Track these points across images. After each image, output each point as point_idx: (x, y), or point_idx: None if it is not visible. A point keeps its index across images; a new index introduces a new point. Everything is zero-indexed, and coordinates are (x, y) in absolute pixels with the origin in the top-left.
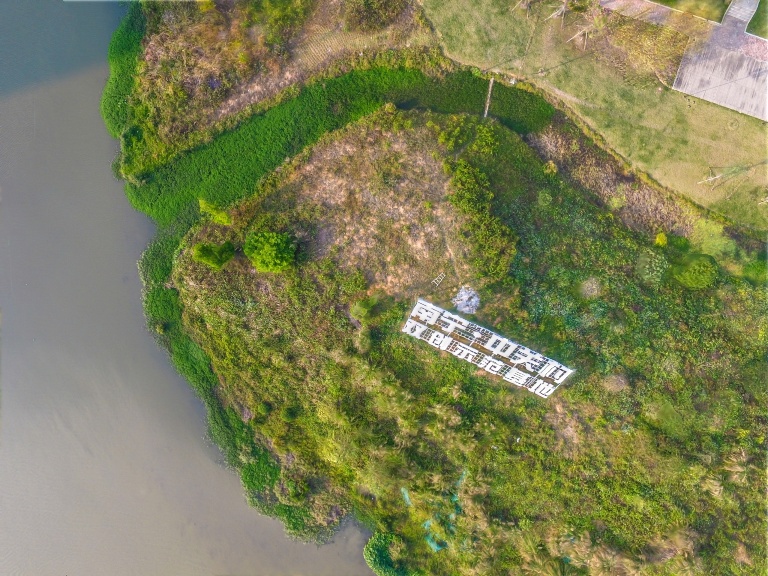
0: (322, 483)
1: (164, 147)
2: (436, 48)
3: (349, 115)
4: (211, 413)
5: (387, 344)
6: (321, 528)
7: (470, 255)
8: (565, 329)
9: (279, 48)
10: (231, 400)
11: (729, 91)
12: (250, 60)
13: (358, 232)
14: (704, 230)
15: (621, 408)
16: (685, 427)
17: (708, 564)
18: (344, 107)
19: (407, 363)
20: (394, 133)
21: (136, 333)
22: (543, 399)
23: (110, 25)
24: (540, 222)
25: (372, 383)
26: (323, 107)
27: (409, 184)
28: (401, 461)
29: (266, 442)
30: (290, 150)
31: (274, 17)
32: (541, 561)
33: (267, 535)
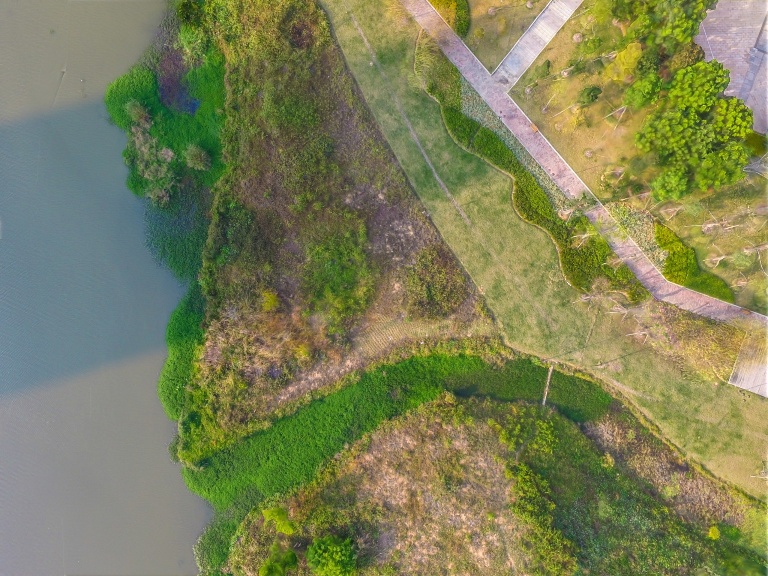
0: None
1: (223, 434)
2: (497, 339)
3: (408, 401)
4: None
5: None
6: None
7: (531, 565)
8: None
9: (341, 340)
10: None
11: None
12: (312, 351)
13: (420, 538)
14: (755, 519)
15: None
16: None
17: None
18: (404, 393)
19: None
20: (455, 427)
21: None
22: None
23: (169, 305)
24: (598, 524)
25: None
26: (383, 393)
27: (471, 490)
28: None
29: None
30: (349, 435)
31: (337, 309)
32: None
33: None
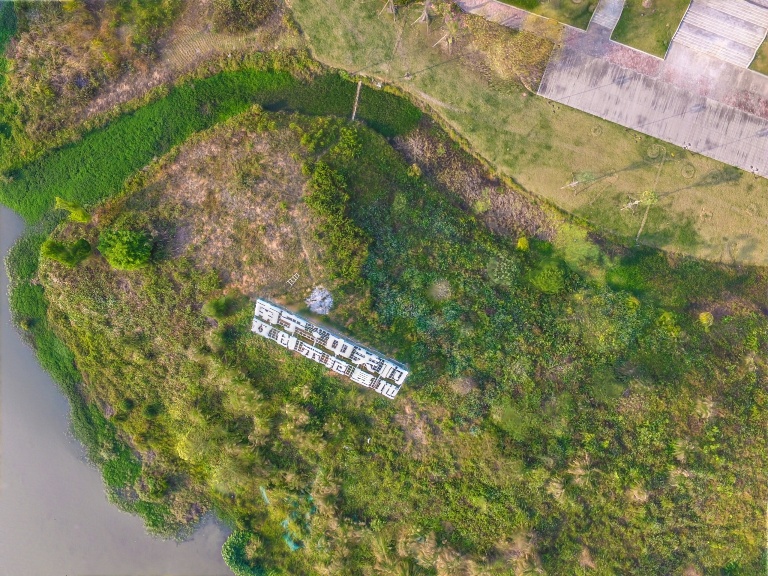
0: (182, 480)
1: (32, 144)
2: (303, 50)
3: (218, 115)
4: (74, 409)
5: (242, 343)
6: (181, 525)
7: (324, 256)
8: (416, 331)
9: (146, 48)
10: (93, 397)
11: (593, 97)
12: (117, 60)
13: (215, 231)
14: (568, 235)
15: (469, 410)
16: (532, 430)
17: (553, 567)
18: (213, 107)
19: (260, 362)
20: (259, 134)
21: (1, 329)
22: (393, 400)
23: None
24: (399, 224)
25: (223, 381)
26: (192, 107)
27: (267, 185)
28: (255, 460)
29: (128, 439)
30: (158, 149)
31: (141, 17)
32: (391, 561)
33: (127, 531)
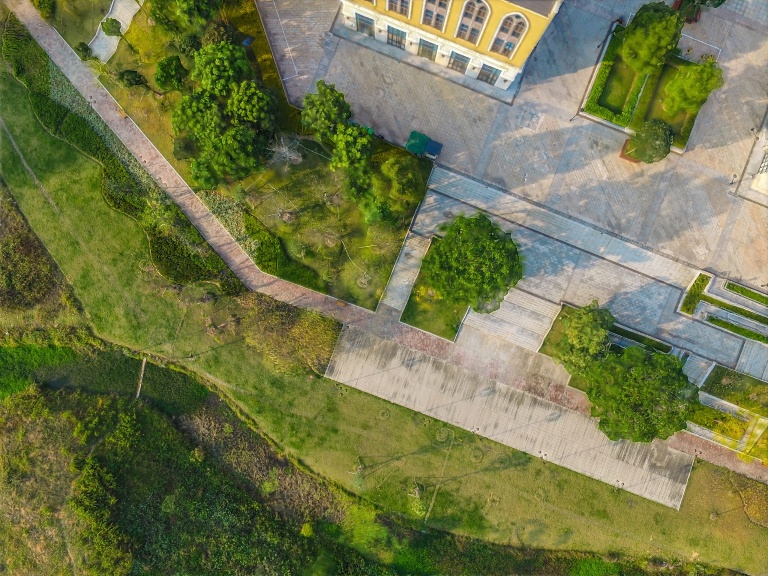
0: None
1: None
2: (84, 330)
3: None
4: None
5: None
6: None
7: (89, 561)
8: None
9: None
10: None
11: (381, 380)
12: None
13: None
14: (356, 516)
15: None
16: None
17: None
18: None
19: None
20: (34, 419)
21: None
22: None
23: None
24: (173, 519)
25: None
26: None
27: (33, 484)
28: None
29: None
30: None
31: None
32: None
33: None
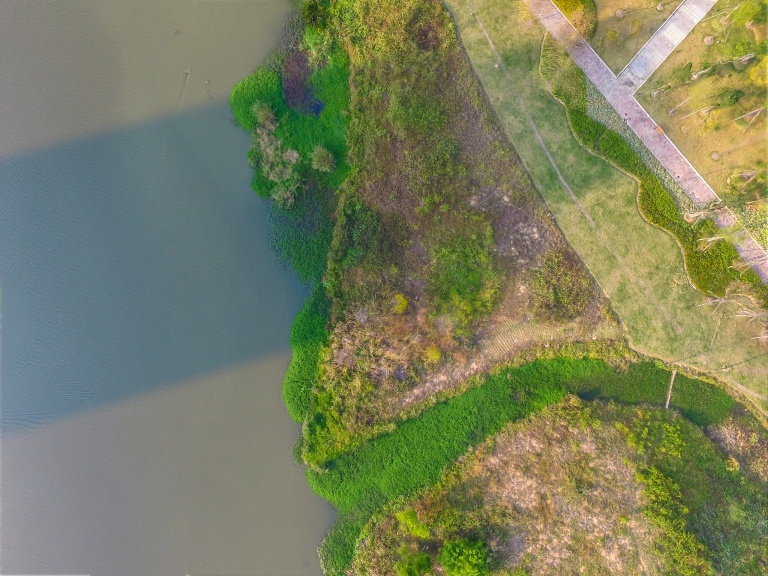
0: None
1: (348, 436)
2: (622, 342)
3: (532, 403)
4: None
5: None
6: None
7: (664, 569)
8: None
9: (468, 343)
10: None
11: None
12: (439, 354)
13: (551, 541)
14: None
15: None
16: None
17: None
18: (528, 396)
19: None
20: (581, 430)
21: None
22: None
23: (293, 307)
24: (727, 528)
25: None
26: (506, 395)
27: (602, 493)
28: None
29: None
30: (472, 438)
31: (464, 312)
32: None
33: None
